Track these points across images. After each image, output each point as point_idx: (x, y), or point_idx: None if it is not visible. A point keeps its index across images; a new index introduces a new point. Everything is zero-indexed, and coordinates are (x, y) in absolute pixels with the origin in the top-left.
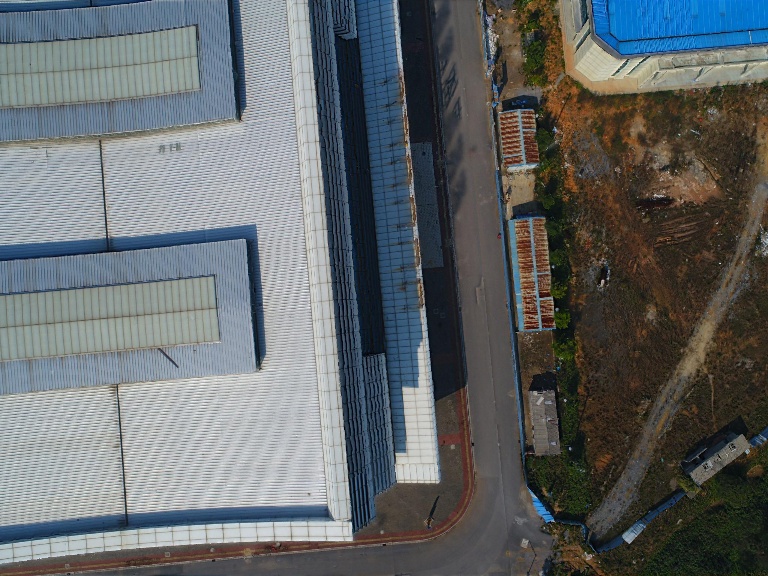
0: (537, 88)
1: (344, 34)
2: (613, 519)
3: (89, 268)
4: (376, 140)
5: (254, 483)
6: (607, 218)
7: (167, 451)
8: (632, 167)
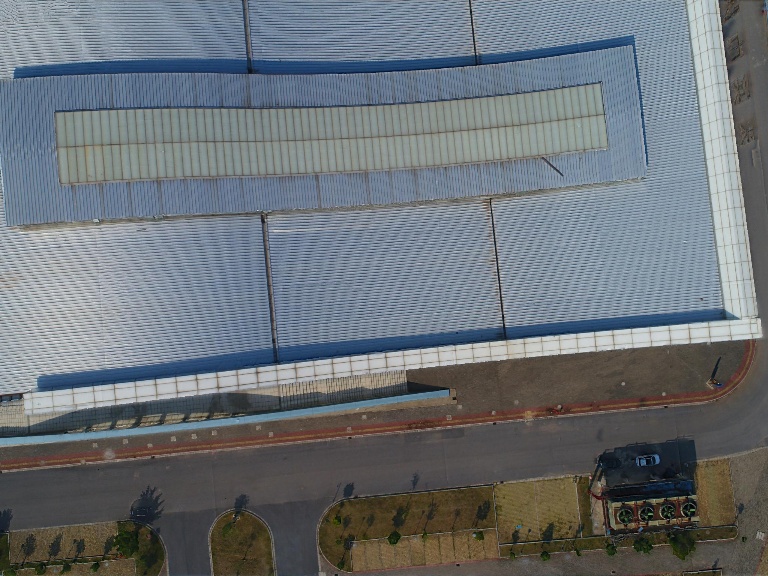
0: None
1: None
2: None
3: (469, 80)
4: None
5: (638, 292)
6: None
7: (544, 264)
8: None
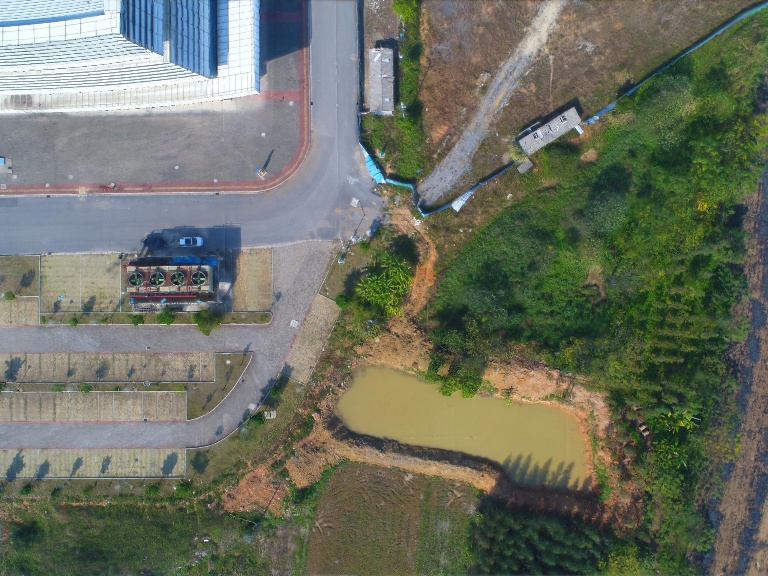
0: None
1: None
2: (444, 187)
3: None
4: None
5: None
6: None
7: None
8: None
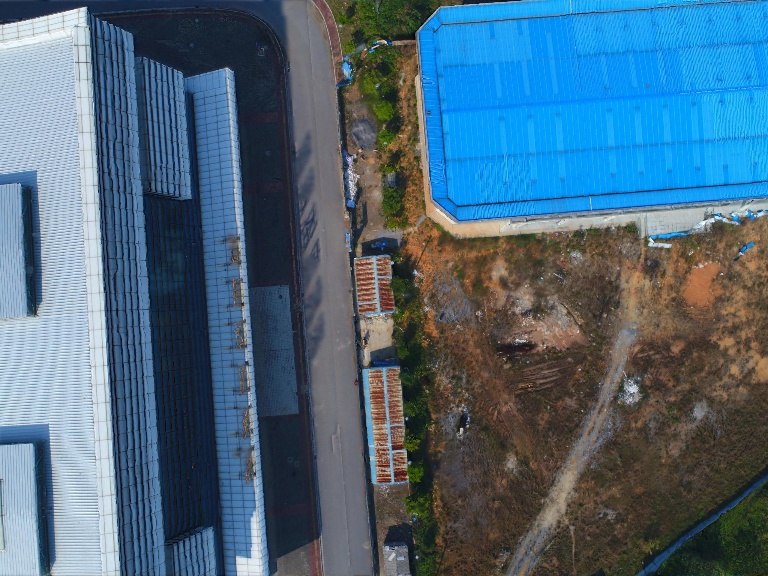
0: (397, 230)
1: (176, 197)
2: None
3: None
4: (214, 299)
5: None
6: (467, 364)
7: None
8: (494, 311)
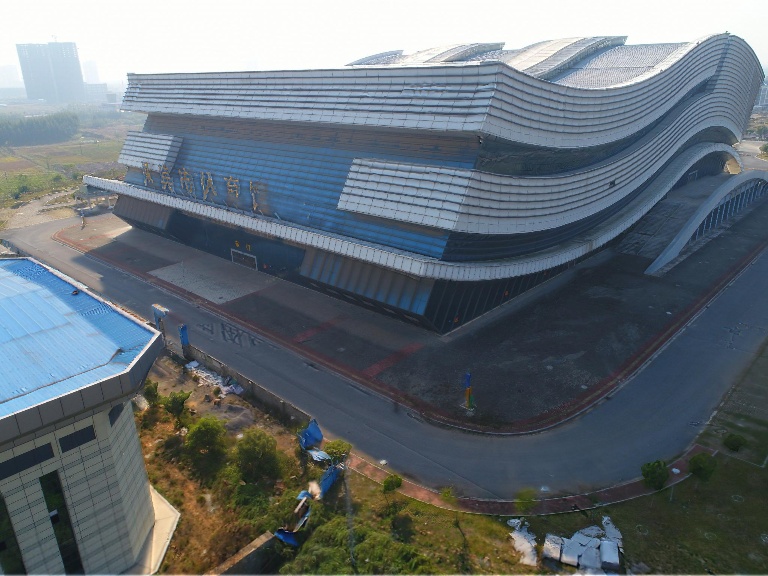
0: None
1: None
2: None
3: None
4: None
5: None
6: None
7: None
8: None
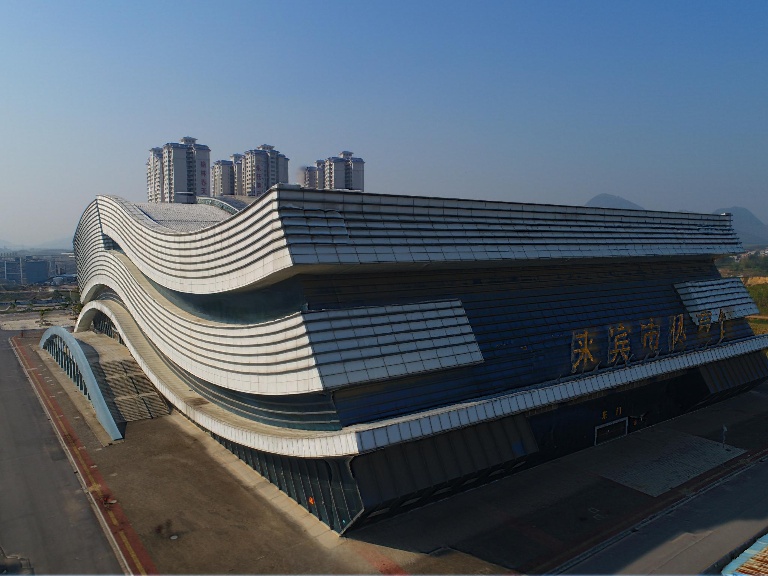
0: None
1: (695, 313)
2: None
3: None
4: None
5: None
6: None
7: None
8: None
